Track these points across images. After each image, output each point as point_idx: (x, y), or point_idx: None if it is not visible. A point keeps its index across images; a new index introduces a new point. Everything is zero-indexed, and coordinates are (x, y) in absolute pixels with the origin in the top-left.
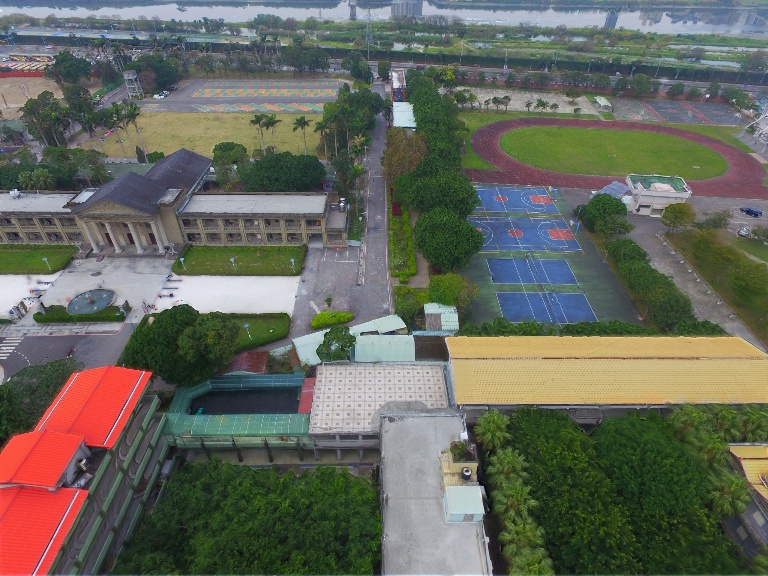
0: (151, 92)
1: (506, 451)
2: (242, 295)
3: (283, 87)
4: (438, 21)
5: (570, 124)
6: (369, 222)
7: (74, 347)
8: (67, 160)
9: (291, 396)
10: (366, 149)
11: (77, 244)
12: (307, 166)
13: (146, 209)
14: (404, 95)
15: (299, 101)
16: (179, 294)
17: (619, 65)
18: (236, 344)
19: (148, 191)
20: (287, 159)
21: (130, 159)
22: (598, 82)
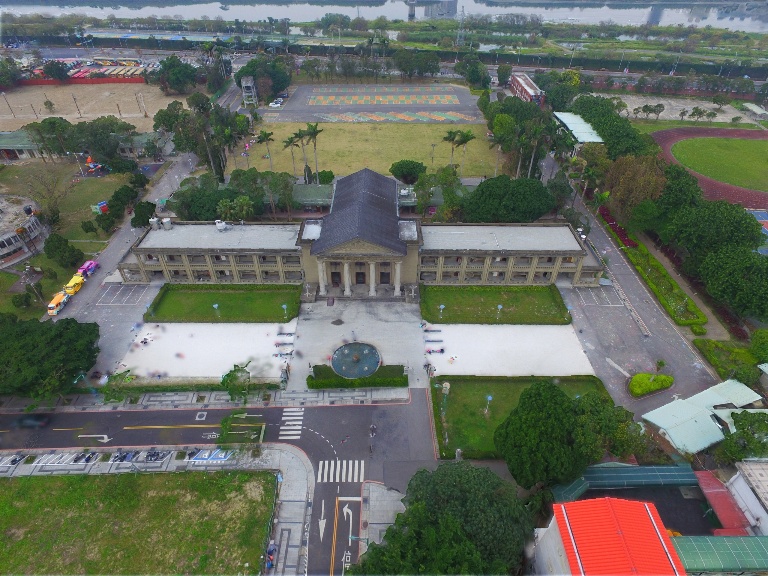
0: (266, 100)
1: None
2: (521, 350)
3: (398, 93)
4: (516, 20)
5: (734, 135)
6: (602, 255)
7: (371, 422)
8: (255, 184)
9: (674, 493)
10: (540, 165)
11: (306, 286)
12: (539, 192)
13: (398, 248)
14: (542, 103)
15: (426, 109)
16: (448, 349)
17: (748, 68)
18: (644, 438)
19: (387, 225)
20: (514, 184)
21: None
22: (741, 87)
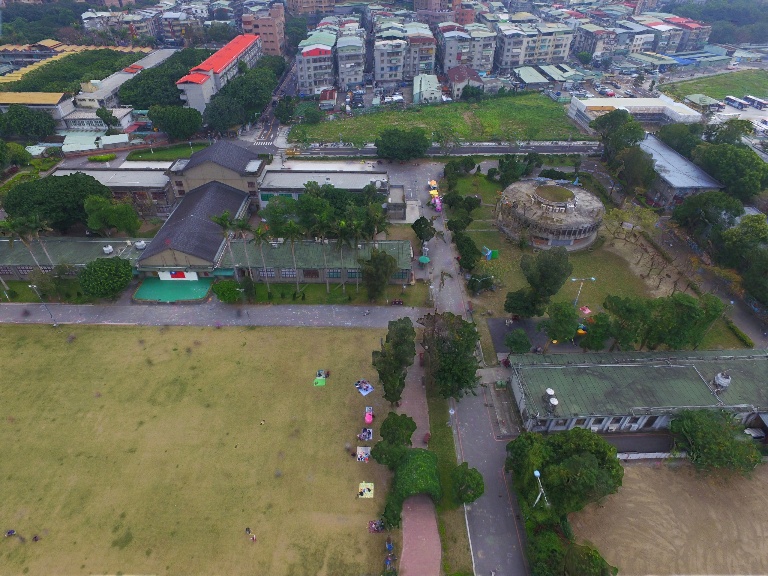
0: None
1: (72, 86)
2: None
3: None
4: None
5: None
6: None
7: None
8: None
9: None
10: None
11: None
12: None
13: None
14: None
15: None
16: None
17: None
18: None
19: None
20: (46, 184)
21: (282, 321)
22: None
